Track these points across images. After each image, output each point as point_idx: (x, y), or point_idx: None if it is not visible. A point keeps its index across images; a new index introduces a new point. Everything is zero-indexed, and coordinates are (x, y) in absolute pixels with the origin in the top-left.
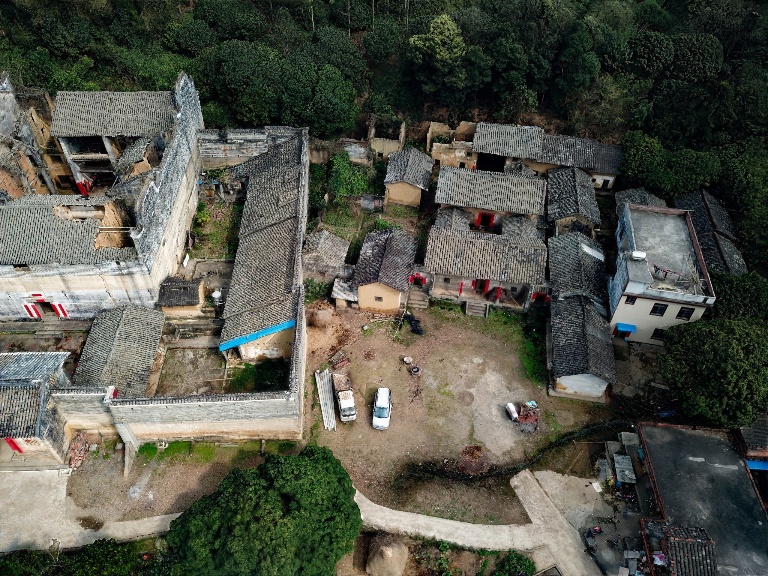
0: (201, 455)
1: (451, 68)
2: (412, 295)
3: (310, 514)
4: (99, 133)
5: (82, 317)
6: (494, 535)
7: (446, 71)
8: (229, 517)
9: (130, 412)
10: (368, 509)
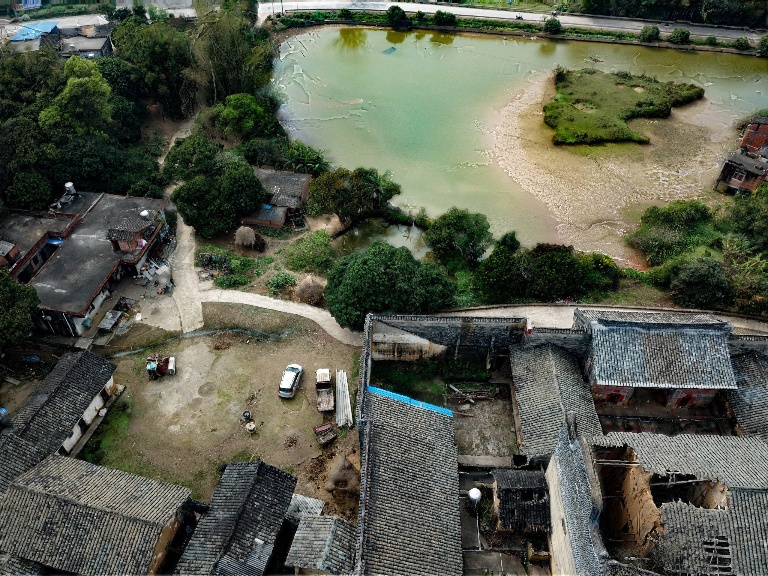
0: None
1: None
2: None
3: None
4: None
5: None
6: (232, 297)
7: None
8: None
9: None
10: (318, 317)
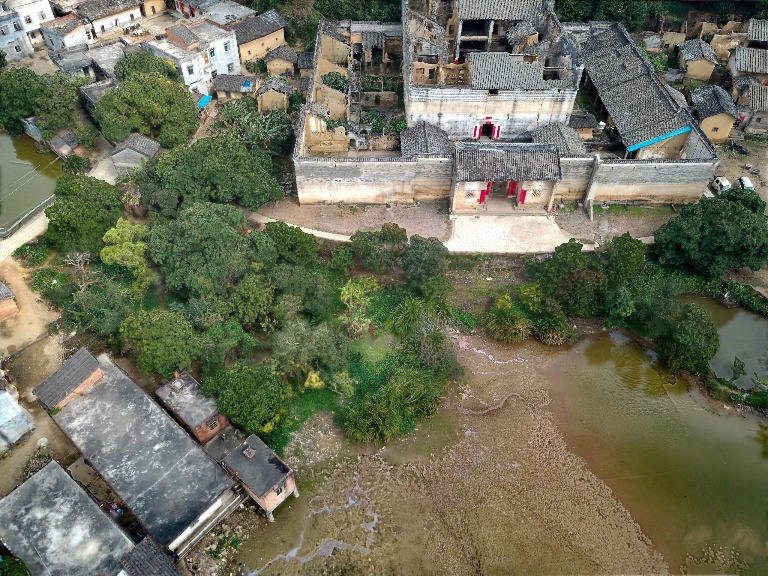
0: (634, 212)
1: None
2: (730, 132)
3: (760, 217)
4: (493, 17)
5: (508, 138)
6: None
7: None
8: (712, 217)
9: (608, 172)
10: None
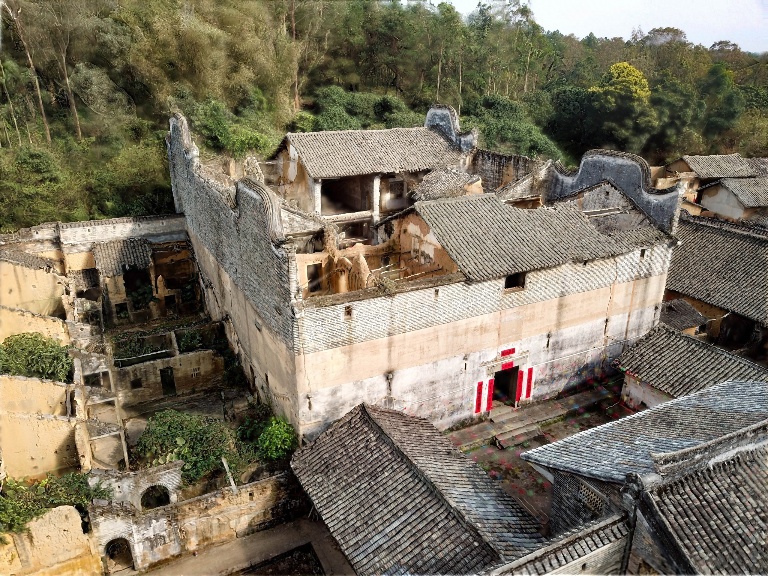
0: None
1: (640, 110)
2: None
3: None
4: (378, 169)
5: (548, 393)
6: None
7: (638, 112)
8: None
9: None
10: None
